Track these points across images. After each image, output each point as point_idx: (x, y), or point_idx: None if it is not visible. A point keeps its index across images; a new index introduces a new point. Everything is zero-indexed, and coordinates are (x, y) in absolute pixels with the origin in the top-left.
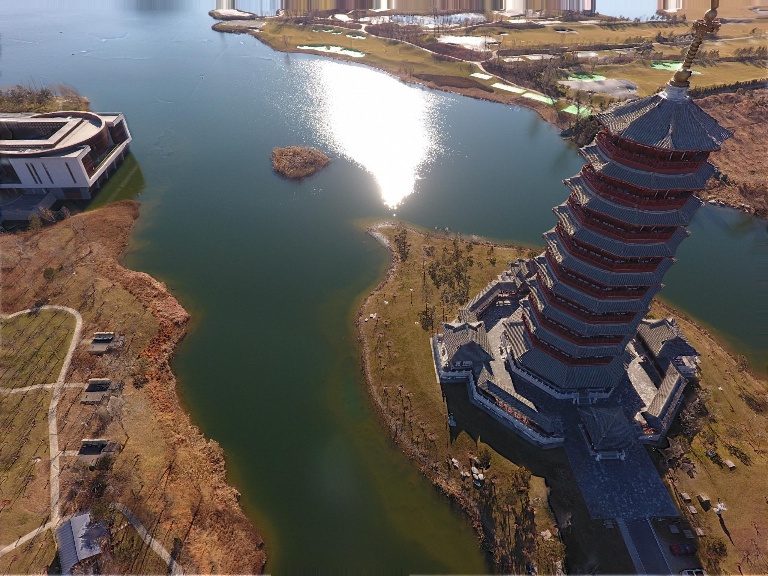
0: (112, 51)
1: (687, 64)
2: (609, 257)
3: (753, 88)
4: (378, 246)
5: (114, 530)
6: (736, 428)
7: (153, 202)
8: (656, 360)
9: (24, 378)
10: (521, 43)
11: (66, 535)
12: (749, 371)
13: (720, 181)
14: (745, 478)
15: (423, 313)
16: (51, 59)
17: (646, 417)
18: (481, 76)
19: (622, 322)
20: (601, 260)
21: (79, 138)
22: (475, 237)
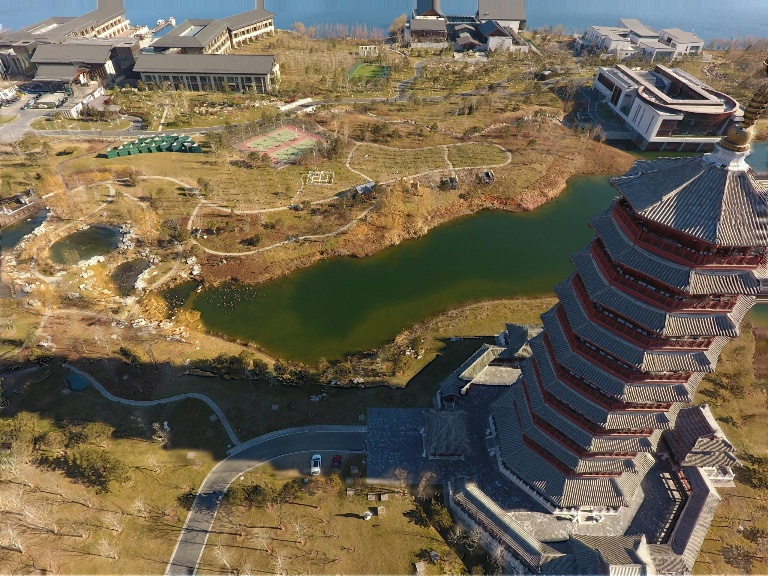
0: None
1: None
2: None
3: None
4: None
5: (372, 199)
6: None
7: None
8: None
9: (455, 159)
10: None
11: None
12: None
13: None
14: None
15: None
16: None
17: None
18: None
19: None
20: None
21: None
22: None
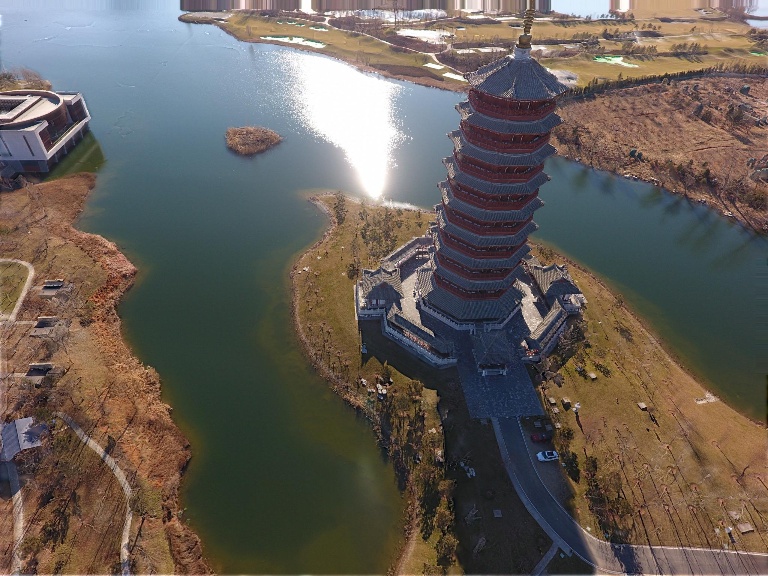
0: (76, 38)
1: (527, 29)
2: (484, 197)
3: (681, 79)
4: (318, 212)
5: (55, 432)
6: (602, 349)
7: (109, 175)
8: (545, 298)
9: None
10: (476, 37)
11: (11, 432)
12: (630, 311)
13: (635, 158)
14: (603, 386)
15: (350, 265)
16: (14, 45)
17: (526, 340)
18: (434, 66)
19: (503, 257)
20: (477, 200)
21: (37, 114)
22: (408, 204)
